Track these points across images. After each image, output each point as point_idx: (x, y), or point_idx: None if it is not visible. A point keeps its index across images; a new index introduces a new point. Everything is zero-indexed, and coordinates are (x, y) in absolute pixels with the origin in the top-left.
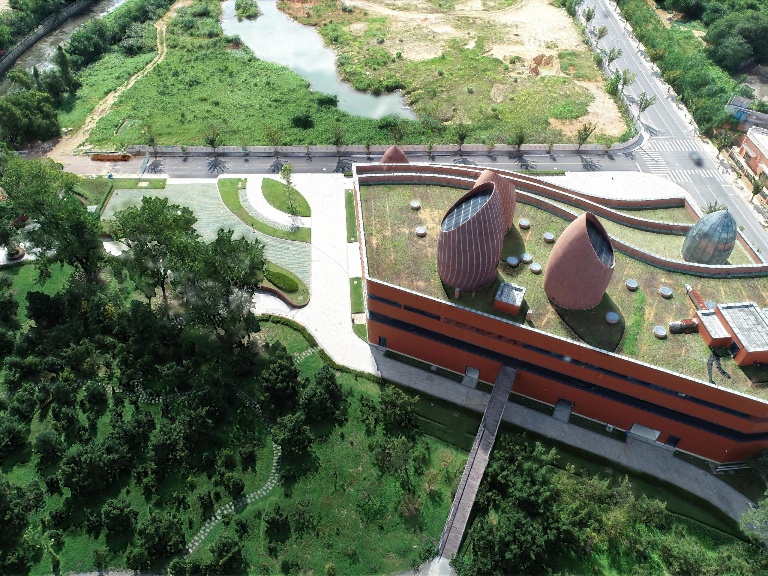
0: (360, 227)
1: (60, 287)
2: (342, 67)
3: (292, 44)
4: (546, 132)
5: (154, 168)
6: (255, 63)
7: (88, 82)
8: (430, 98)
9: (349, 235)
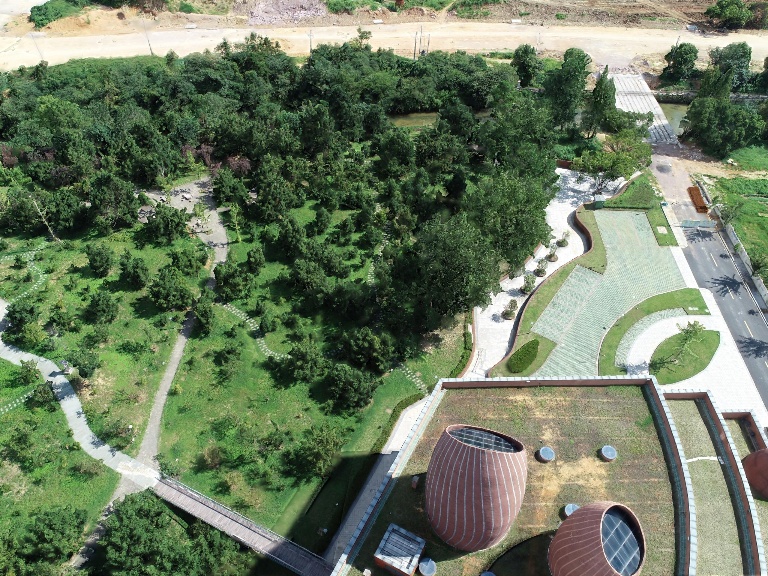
0: None
1: None
2: None
3: None
4: None
5: (695, 233)
6: None
7: None
8: None
9: None
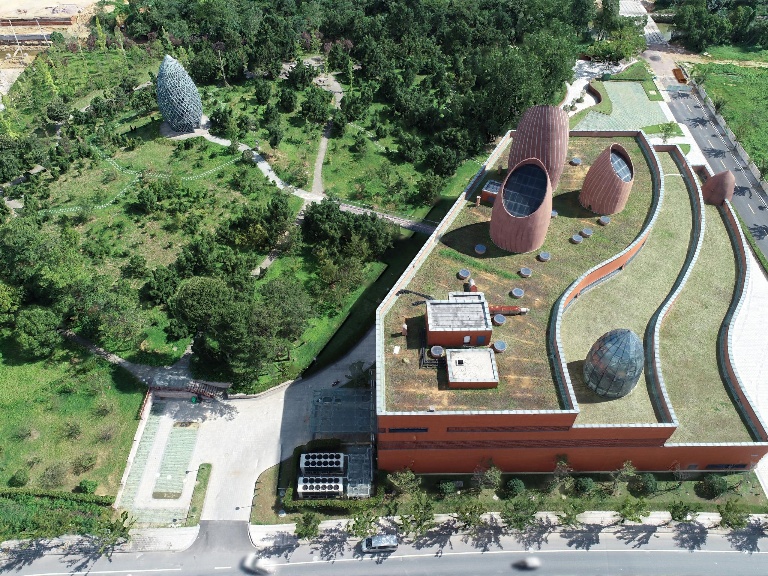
0: None
1: None
2: None
3: None
4: None
5: (676, 95)
6: None
7: None
8: None
9: None
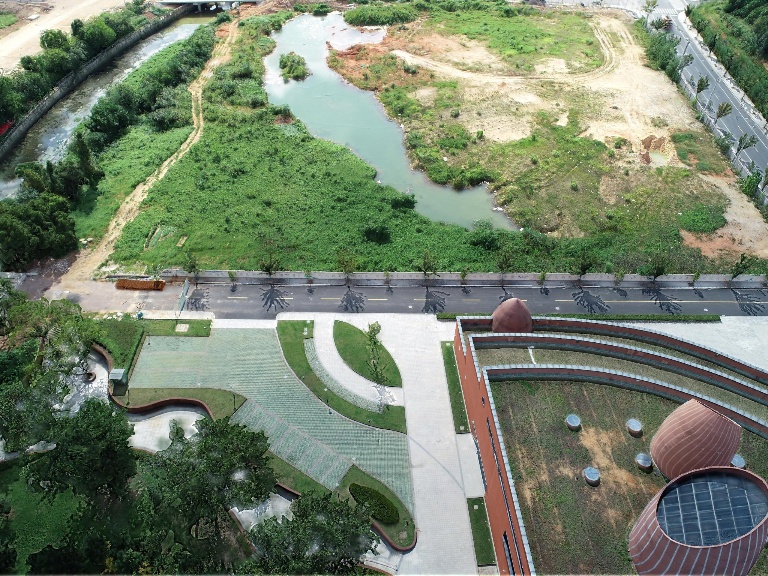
0: (506, 470)
1: (75, 506)
2: (414, 150)
3: (349, 114)
4: (681, 252)
5: (195, 302)
6: (310, 144)
7: (112, 170)
8: (526, 197)
9: (456, 421)
